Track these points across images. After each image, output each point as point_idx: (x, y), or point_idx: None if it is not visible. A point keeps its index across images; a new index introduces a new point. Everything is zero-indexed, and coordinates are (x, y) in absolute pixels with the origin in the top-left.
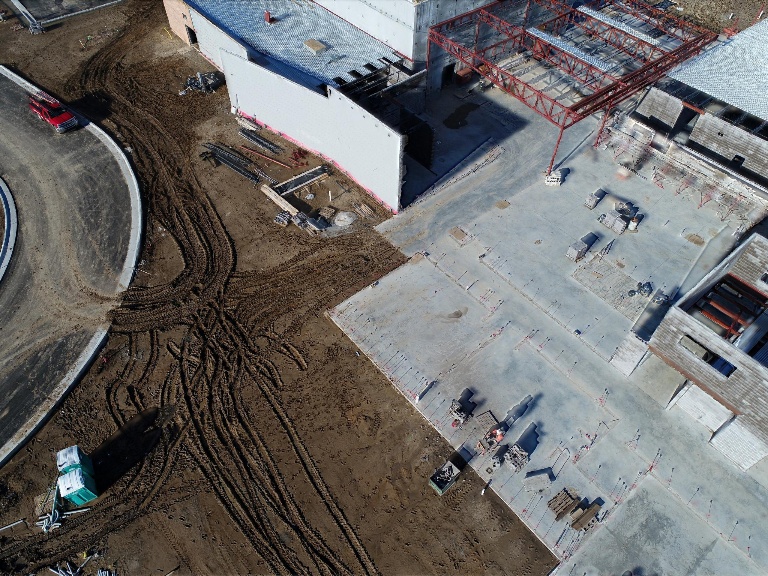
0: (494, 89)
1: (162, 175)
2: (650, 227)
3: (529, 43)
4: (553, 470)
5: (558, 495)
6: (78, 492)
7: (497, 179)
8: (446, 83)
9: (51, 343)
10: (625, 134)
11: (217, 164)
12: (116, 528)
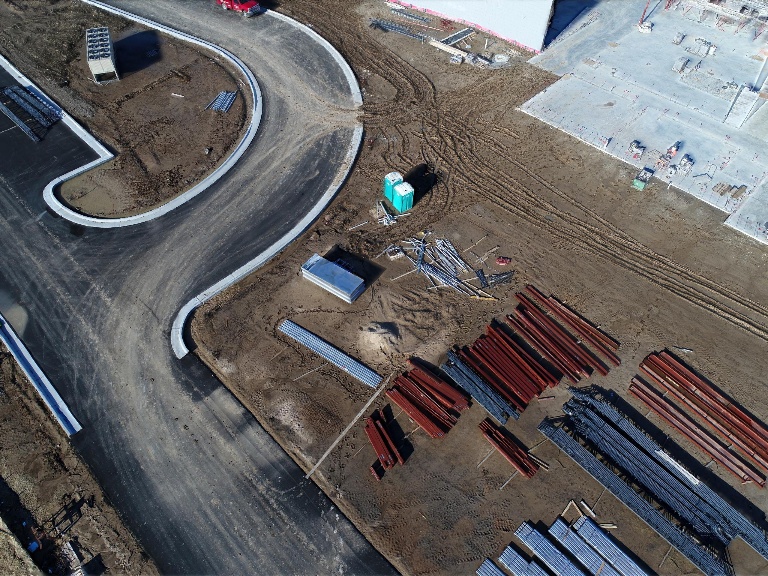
0: None
1: (346, 40)
2: (723, 53)
3: None
4: (709, 174)
5: (717, 185)
6: (409, 196)
7: (603, 31)
8: None
9: (325, 136)
10: None
11: (386, 31)
12: (434, 221)
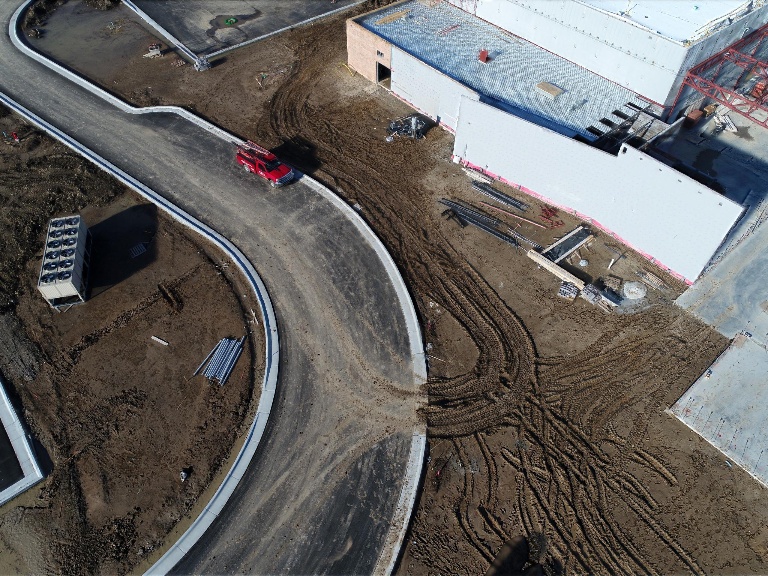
0: (726, 133)
1: (407, 237)
2: None
3: (743, 79)
4: None
5: None
6: None
7: None
8: None
9: (367, 451)
10: None
11: (464, 224)
12: None
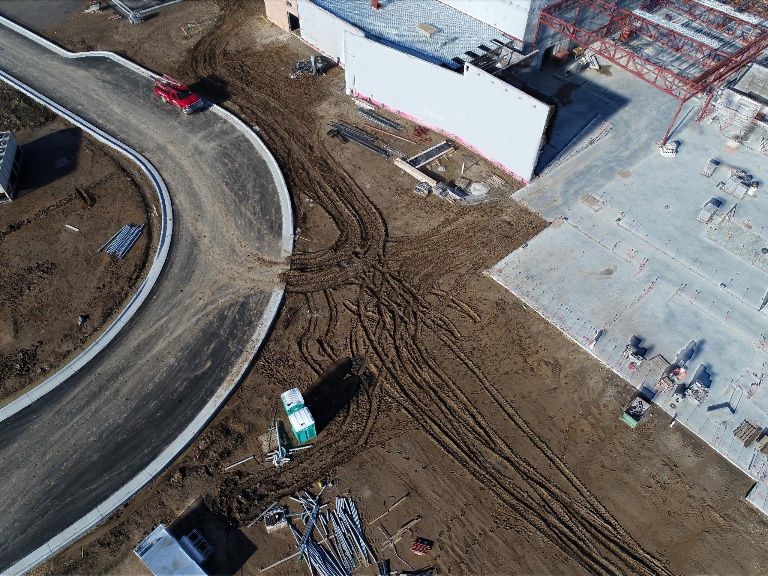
0: (590, 70)
1: (295, 151)
2: (767, 192)
3: None
4: (731, 404)
5: (741, 425)
6: (307, 429)
7: (614, 151)
8: (543, 65)
9: (233, 303)
10: (729, 108)
11: (345, 141)
12: (341, 462)
